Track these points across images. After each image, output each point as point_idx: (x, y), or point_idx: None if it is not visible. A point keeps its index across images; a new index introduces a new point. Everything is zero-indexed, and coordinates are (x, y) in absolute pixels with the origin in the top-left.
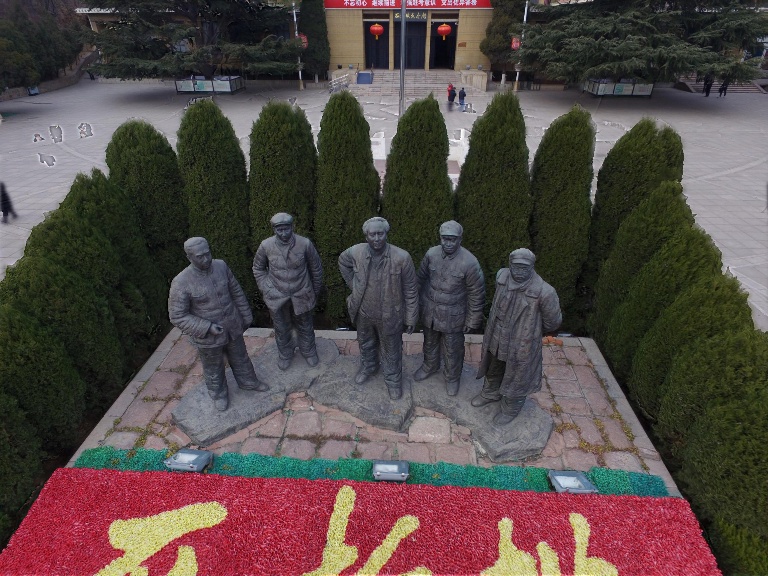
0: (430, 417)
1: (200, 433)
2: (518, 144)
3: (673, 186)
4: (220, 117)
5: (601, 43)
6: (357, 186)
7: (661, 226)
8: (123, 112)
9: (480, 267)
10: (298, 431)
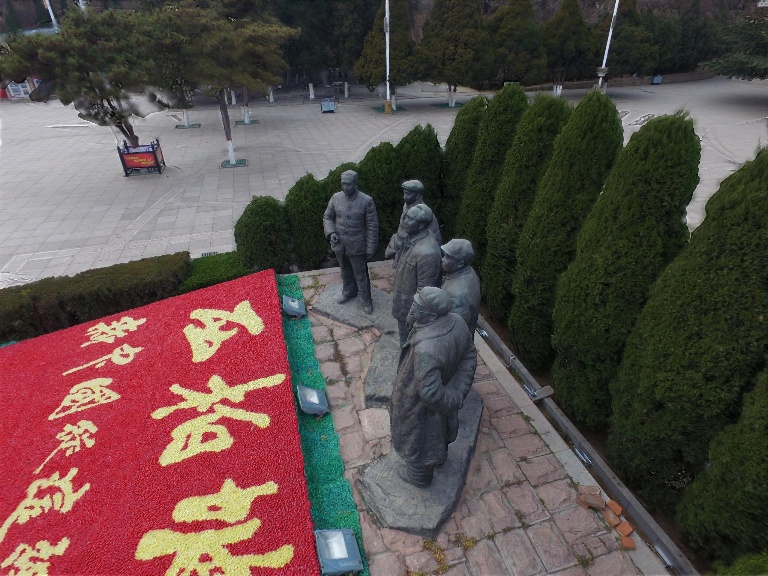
0: None
1: (318, 303)
2: (761, 220)
3: None
4: (515, 102)
5: None
6: (557, 200)
7: None
8: (704, 111)
9: (462, 305)
10: (341, 345)
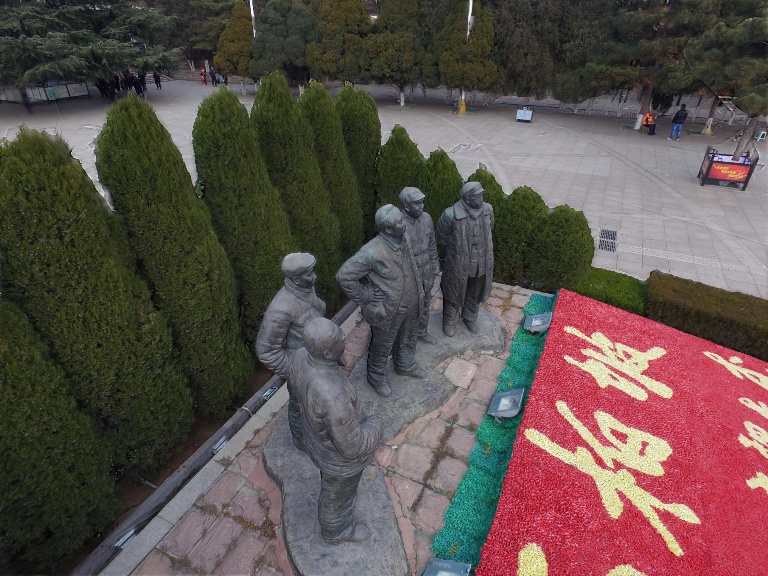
0: (448, 366)
1: (394, 571)
2: None
3: (402, 128)
4: None
5: (24, 42)
6: (206, 218)
7: (412, 158)
8: None
9: None
10: (424, 467)
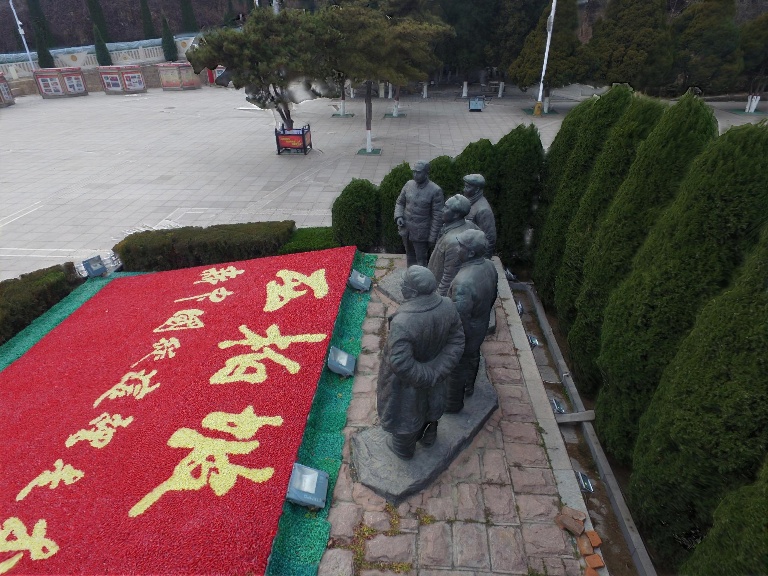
0: None
1: (383, 282)
2: None
3: None
4: (618, 105)
5: None
6: (627, 211)
7: None
8: None
9: (464, 293)
10: None
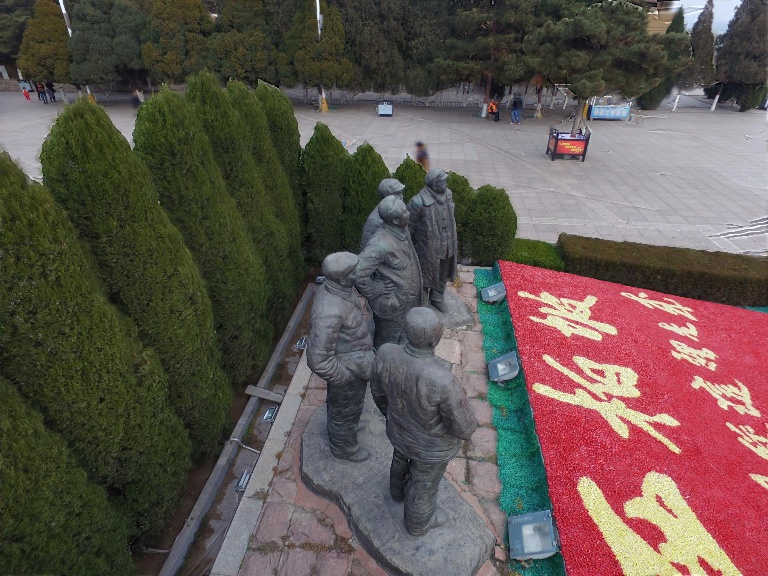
0: None
1: (484, 540)
2: None
3: None
4: None
5: None
6: None
7: (340, 154)
8: None
9: None
10: None
